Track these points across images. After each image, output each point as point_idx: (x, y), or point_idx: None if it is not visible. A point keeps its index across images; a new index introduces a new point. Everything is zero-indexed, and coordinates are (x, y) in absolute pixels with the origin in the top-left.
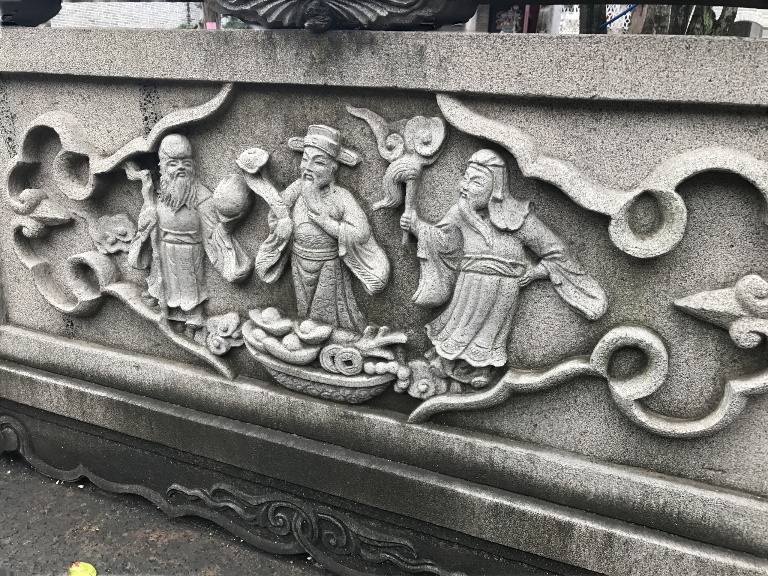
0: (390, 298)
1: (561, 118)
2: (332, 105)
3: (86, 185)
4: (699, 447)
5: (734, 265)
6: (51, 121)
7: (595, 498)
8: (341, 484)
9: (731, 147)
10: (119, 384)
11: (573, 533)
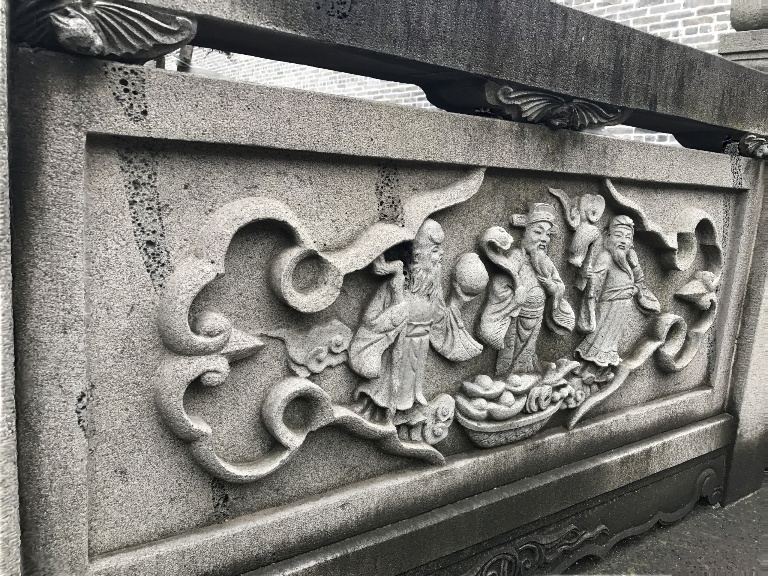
0: (555, 336)
1: (645, 193)
2: (538, 187)
3: (323, 290)
4: (675, 374)
5: (691, 268)
6: (278, 212)
7: (650, 427)
8: (541, 506)
9: (695, 207)
10: (316, 542)
11: (651, 454)
